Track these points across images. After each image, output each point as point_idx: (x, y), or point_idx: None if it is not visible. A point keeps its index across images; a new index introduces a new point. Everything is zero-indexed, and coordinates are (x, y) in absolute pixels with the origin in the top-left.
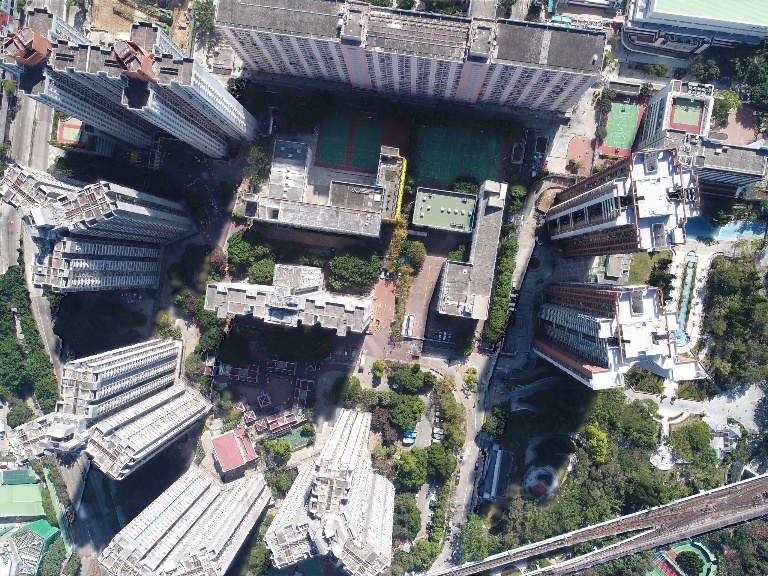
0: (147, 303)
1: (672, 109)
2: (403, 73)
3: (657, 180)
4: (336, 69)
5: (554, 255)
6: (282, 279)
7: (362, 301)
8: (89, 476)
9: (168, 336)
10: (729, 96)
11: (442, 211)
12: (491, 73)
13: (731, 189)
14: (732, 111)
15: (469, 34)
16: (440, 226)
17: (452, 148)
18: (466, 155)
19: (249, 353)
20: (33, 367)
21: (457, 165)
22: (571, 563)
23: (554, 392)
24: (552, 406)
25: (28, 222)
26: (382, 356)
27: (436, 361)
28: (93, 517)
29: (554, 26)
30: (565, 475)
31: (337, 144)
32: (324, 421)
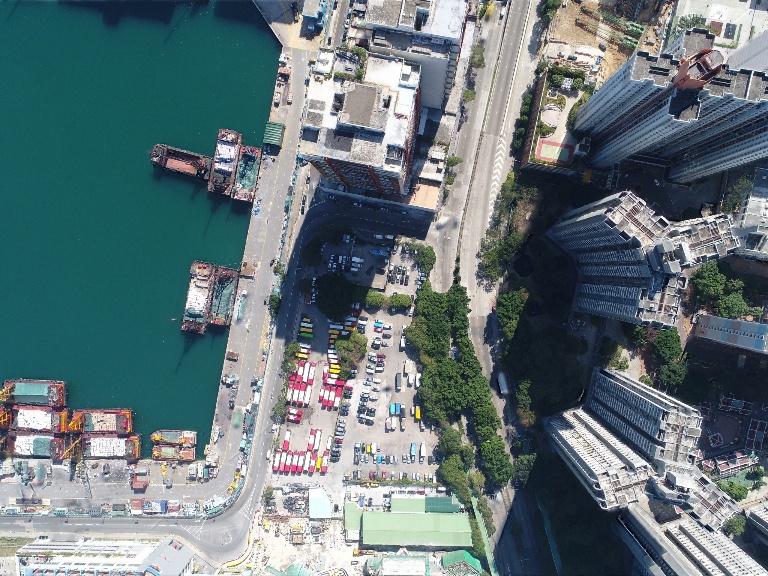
0: (589, 330)
1: None
2: None
3: None
4: None
5: None
6: None
7: None
8: (513, 507)
9: None
10: None
11: None
12: None
13: None
14: None
15: None
16: None
17: None
18: None
19: (709, 390)
20: (476, 392)
21: None
22: None
23: None
24: None
25: (655, 255)
26: None
27: None
28: (519, 551)
29: None
30: None
31: None
32: None
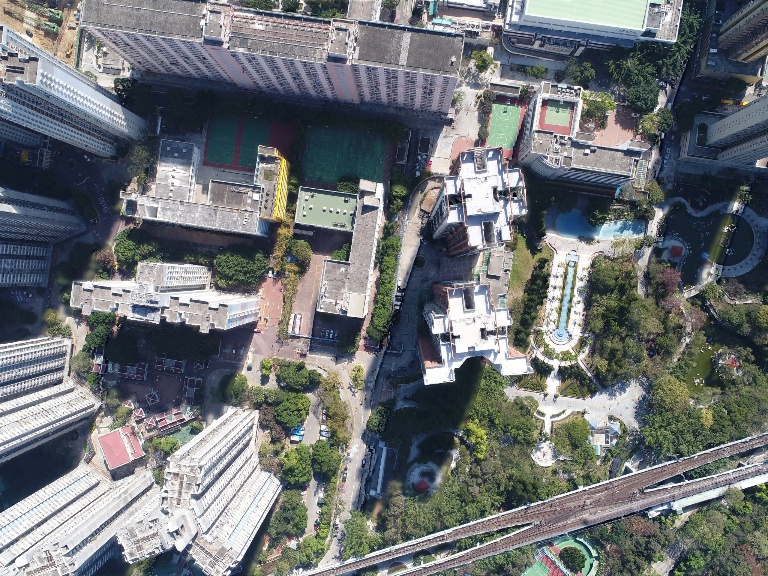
0: (37, 301)
1: (543, 110)
2: (276, 73)
3: (485, 178)
4: (216, 69)
5: (439, 254)
6: (145, 276)
7: (246, 299)
8: None
9: (58, 334)
10: (604, 98)
11: (324, 210)
12: (358, 74)
13: (610, 189)
14: (610, 113)
15: (329, 35)
16: (322, 225)
17: (338, 148)
18: (352, 155)
19: (136, 351)
20: None
21: (343, 165)
22: (451, 559)
23: (434, 389)
24: (433, 403)
25: None
26: (270, 354)
27: (323, 359)
28: None
29: (413, 28)
30: (448, 472)
31: (225, 144)
32: (213, 419)
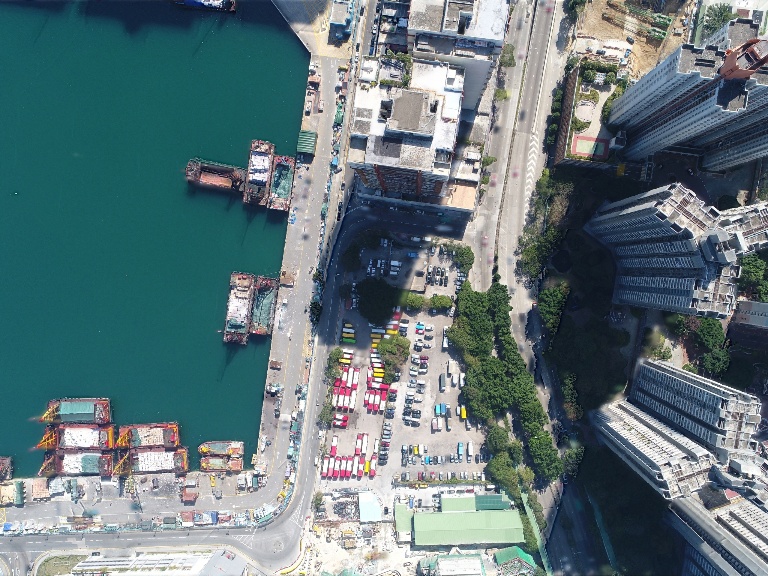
0: (630, 322)
1: None
2: None
3: None
4: None
5: None
6: None
7: None
8: (562, 501)
9: None
10: None
11: None
12: None
13: None
14: None
15: None
16: None
17: None
18: None
19: None
20: (521, 389)
21: None
22: None
23: None
24: None
25: (708, 246)
26: None
27: None
28: (571, 544)
29: None
30: None
31: None
32: None
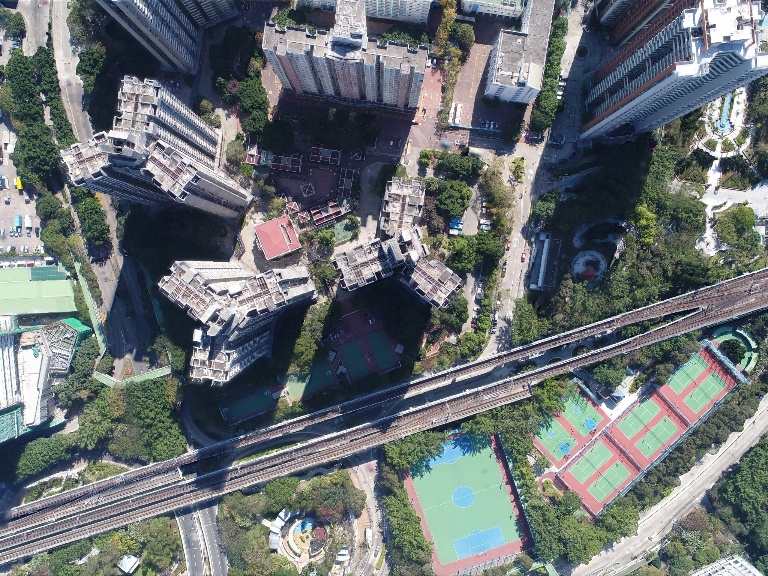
0: (184, 92)
1: None
2: None
3: None
4: None
5: (601, 43)
6: (345, 13)
7: None
8: (122, 274)
9: None
10: None
11: None
12: None
13: None
14: None
15: None
16: (491, 3)
17: None
18: None
19: (293, 138)
20: None
21: None
22: (619, 345)
23: (604, 172)
24: (601, 188)
25: None
26: (428, 147)
27: (483, 151)
28: (127, 314)
29: None
30: (612, 262)
31: None
32: (368, 214)
